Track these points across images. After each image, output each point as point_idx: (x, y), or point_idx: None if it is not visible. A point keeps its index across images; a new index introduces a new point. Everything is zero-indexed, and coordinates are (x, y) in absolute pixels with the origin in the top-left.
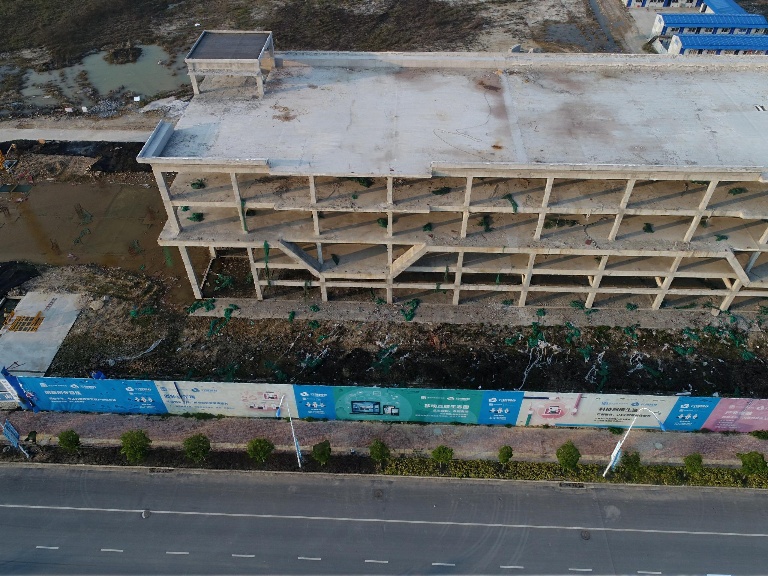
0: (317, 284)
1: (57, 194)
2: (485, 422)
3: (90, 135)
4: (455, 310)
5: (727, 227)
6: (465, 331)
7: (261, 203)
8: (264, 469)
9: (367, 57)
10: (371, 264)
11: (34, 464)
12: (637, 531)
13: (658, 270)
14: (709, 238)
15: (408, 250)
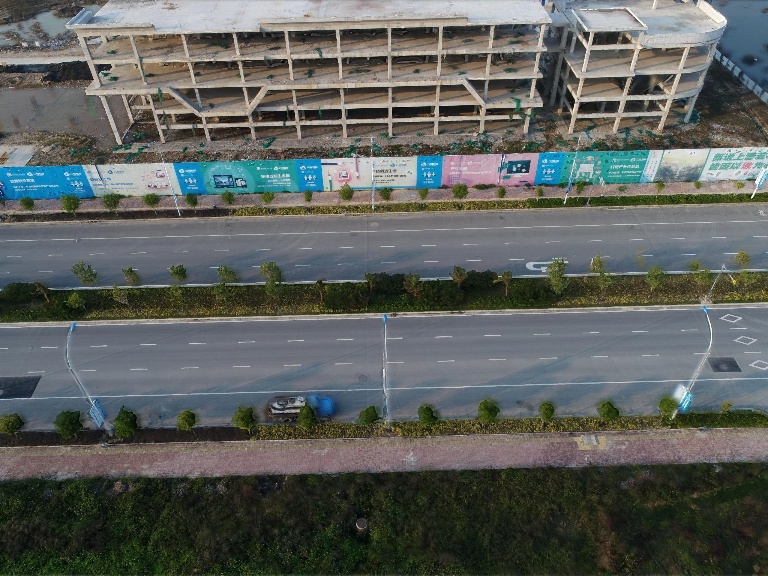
0: (201, 126)
1: (17, 95)
2: (304, 190)
3: (42, 60)
4: (299, 142)
5: (469, 69)
6: (303, 151)
7: (153, 59)
8: (156, 218)
9: None
10: (235, 107)
11: (4, 224)
12: (386, 231)
13: (428, 101)
14: (454, 74)
15: (258, 93)
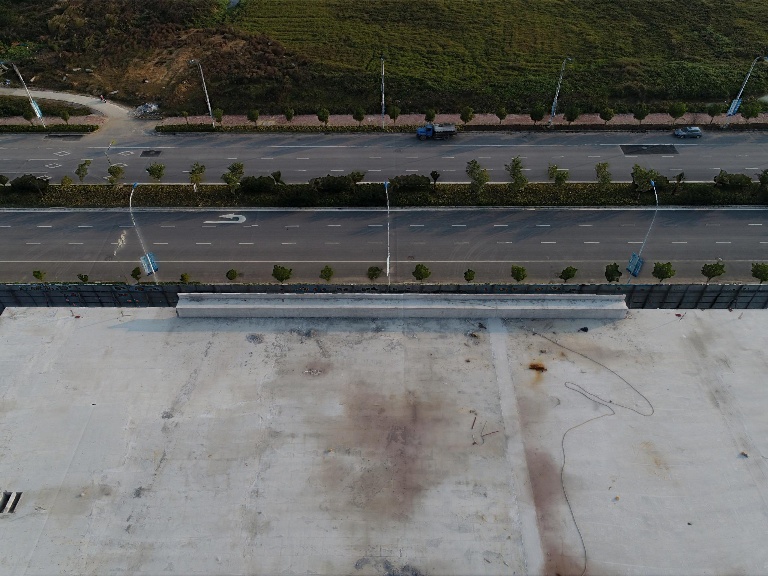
0: None
1: None
2: None
3: None
4: None
5: None
6: None
7: None
8: None
9: None
10: None
11: None
12: (375, 261)
13: None
14: None
15: None
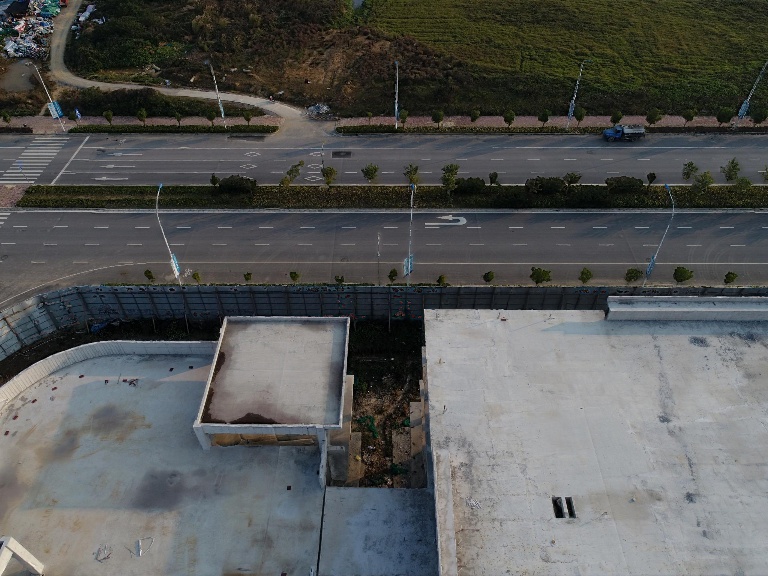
0: None
1: None
2: None
3: None
4: None
5: None
6: None
7: None
8: None
9: None
10: None
11: None
12: (615, 263)
13: None
14: None
15: None
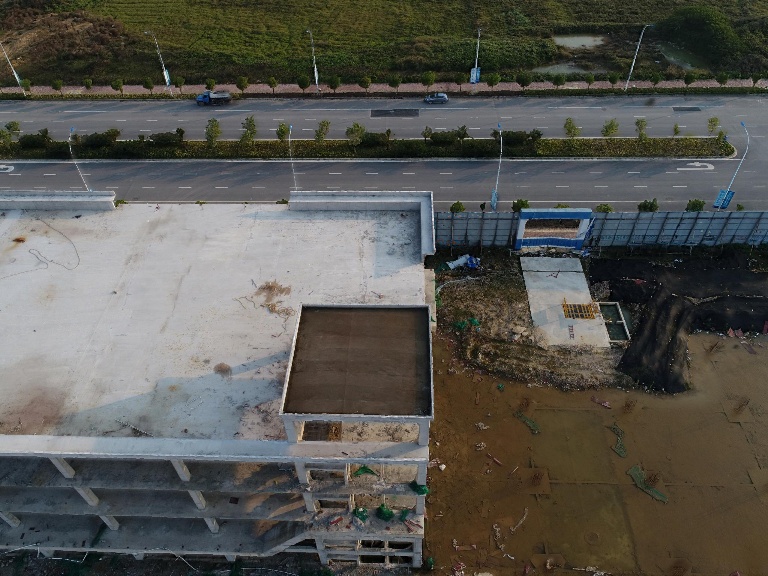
0: None
1: (744, 546)
2: None
3: None
4: None
5: None
6: None
7: None
8: None
9: (92, 445)
10: None
11: None
12: None
13: None
14: None
15: None
